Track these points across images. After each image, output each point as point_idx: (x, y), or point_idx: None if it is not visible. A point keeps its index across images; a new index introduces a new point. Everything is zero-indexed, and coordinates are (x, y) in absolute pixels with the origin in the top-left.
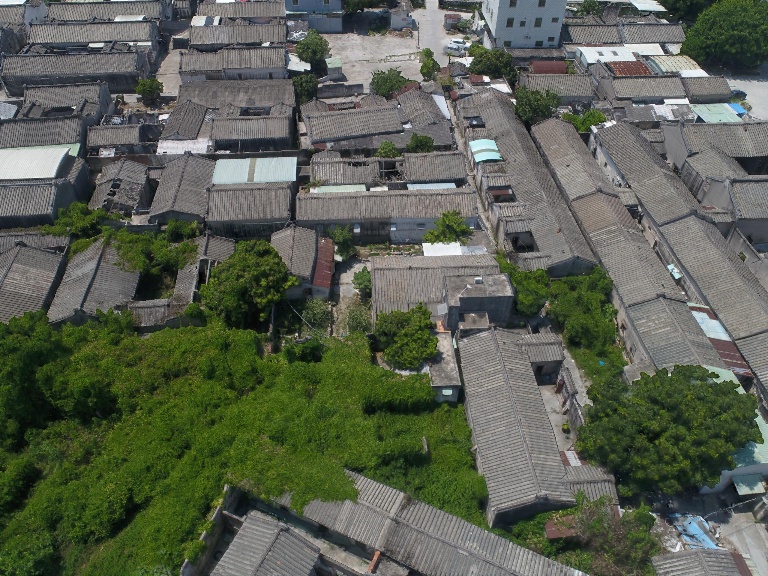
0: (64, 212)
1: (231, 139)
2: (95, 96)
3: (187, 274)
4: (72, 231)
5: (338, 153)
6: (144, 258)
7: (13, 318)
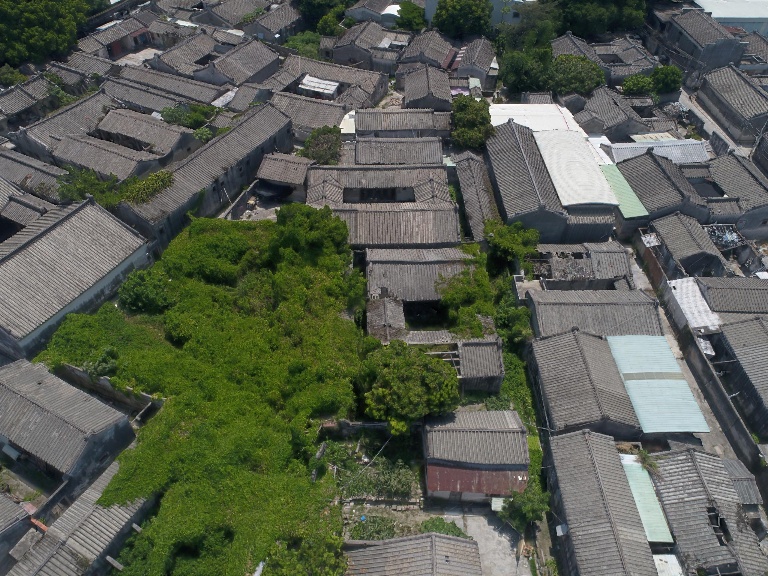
0: (517, 226)
1: (733, 349)
2: (754, 204)
3: (438, 336)
4: (489, 238)
5: (759, 499)
6: (461, 298)
7: (338, 219)
